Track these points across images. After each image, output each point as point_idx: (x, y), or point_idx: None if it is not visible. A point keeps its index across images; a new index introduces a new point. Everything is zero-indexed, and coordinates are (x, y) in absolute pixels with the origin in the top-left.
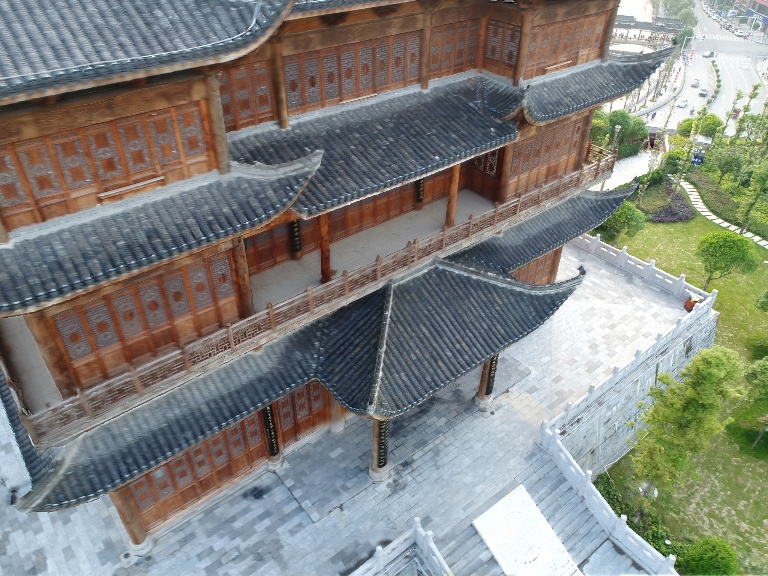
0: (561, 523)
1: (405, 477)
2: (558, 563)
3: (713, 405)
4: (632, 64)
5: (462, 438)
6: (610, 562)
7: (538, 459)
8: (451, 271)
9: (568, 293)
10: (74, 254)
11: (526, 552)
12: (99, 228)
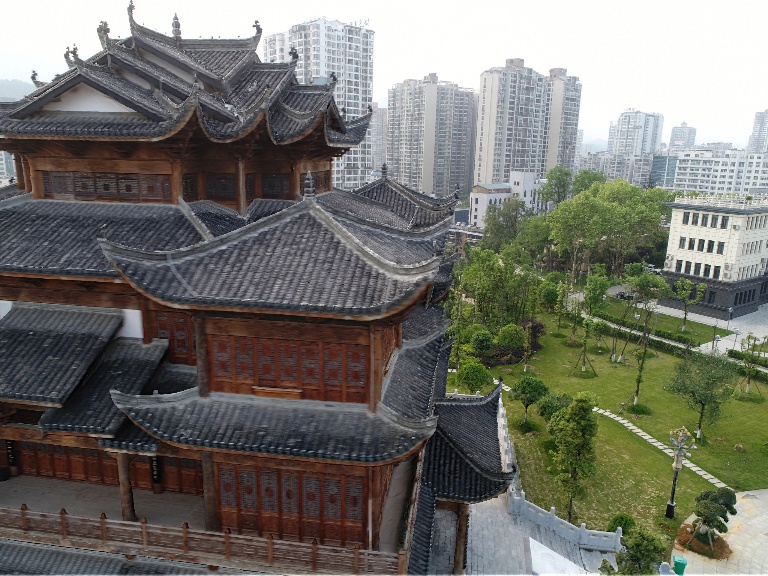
0: (559, 550)
1: (472, 573)
2: (578, 573)
3: (595, 425)
4: (441, 265)
5: (473, 533)
6: (593, 558)
7: (520, 520)
8: (442, 404)
9: (498, 396)
10: (404, 407)
11: (564, 574)
12: (395, 391)
